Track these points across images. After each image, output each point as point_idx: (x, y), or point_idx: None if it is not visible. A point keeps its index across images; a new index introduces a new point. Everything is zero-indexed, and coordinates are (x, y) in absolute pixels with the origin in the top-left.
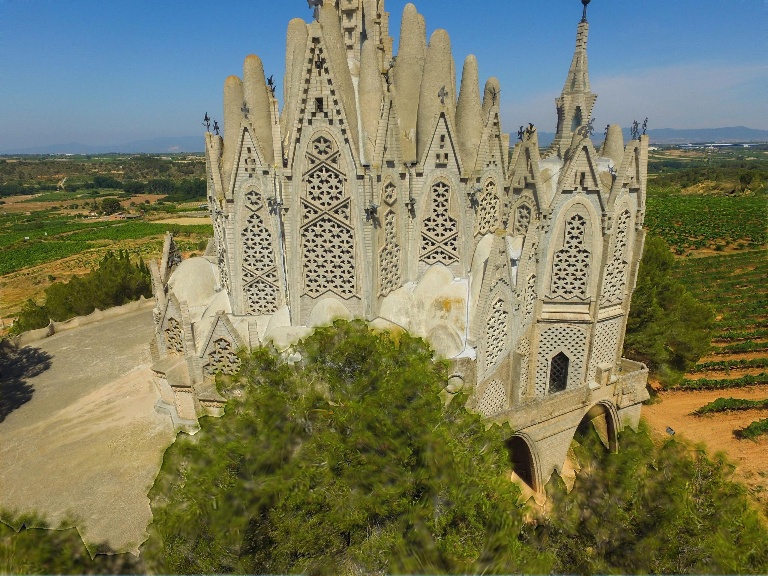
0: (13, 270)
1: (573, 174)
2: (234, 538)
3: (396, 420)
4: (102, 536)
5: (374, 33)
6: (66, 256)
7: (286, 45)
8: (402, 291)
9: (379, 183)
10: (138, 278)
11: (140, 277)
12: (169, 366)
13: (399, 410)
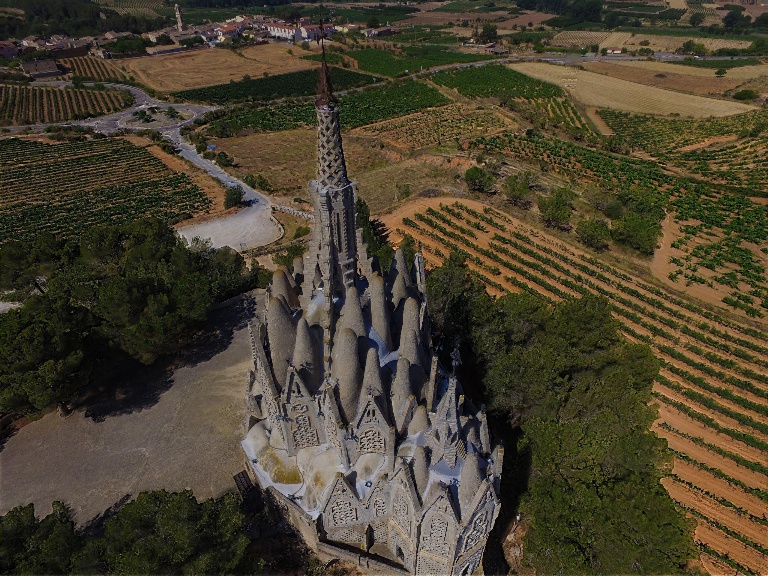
0: (372, 122)
1: (399, 474)
2: (76, 572)
3: (134, 569)
4: (185, 463)
5: (325, 300)
6: (411, 112)
7: None
8: (312, 451)
9: (289, 404)
10: None
11: None
12: None
13: (137, 567)
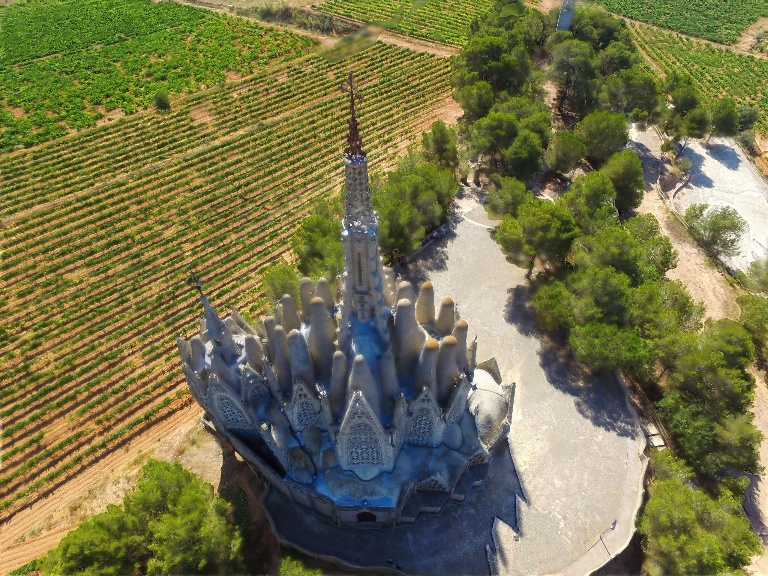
0: None
1: None
2: None
3: None
4: None
5: None
6: None
7: None
8: None
9: None
10: (662, 542)
11: (663, 545)
12: None
13: None
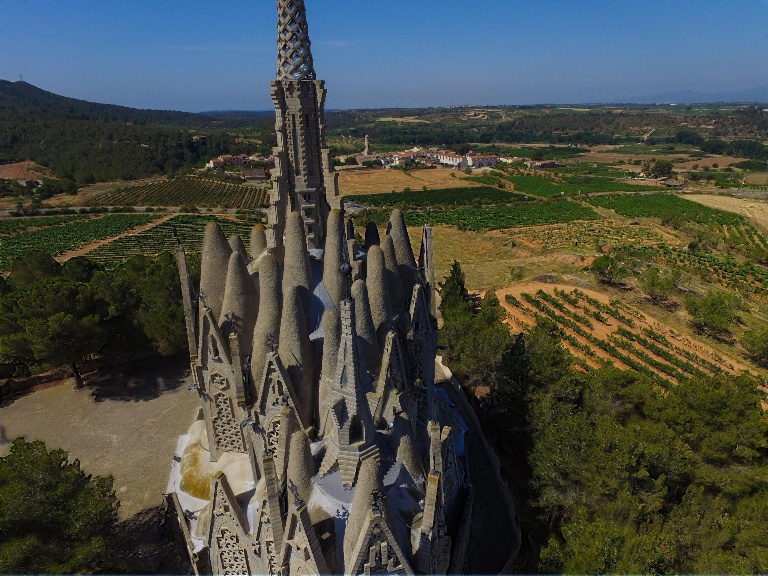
0: (511, 226)
1: None
2: None
3: None
4: (140, 461)
5: (270, 235)
6: (555, 223)
7: None
8: (234, 457)
9: (206, 371)
10: None
11: None
12: None
13: None
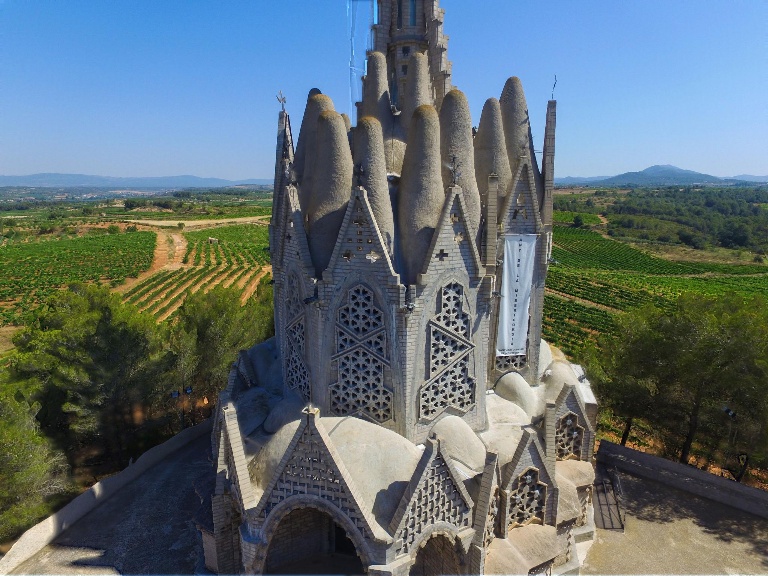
0: None
1: None
2: None
3: None
4: None
5: None
6: None
7: (421, 81)
8: None
9: None
10: None
11: None
12: (516, 562)
13: None
